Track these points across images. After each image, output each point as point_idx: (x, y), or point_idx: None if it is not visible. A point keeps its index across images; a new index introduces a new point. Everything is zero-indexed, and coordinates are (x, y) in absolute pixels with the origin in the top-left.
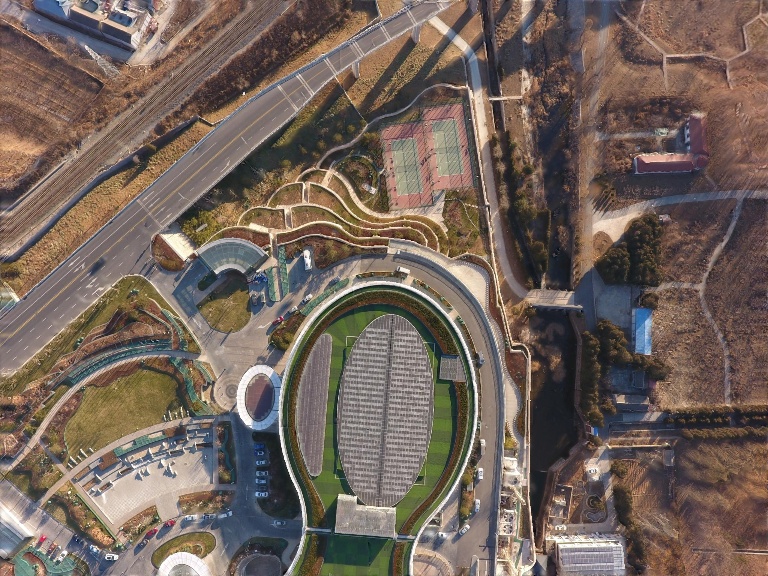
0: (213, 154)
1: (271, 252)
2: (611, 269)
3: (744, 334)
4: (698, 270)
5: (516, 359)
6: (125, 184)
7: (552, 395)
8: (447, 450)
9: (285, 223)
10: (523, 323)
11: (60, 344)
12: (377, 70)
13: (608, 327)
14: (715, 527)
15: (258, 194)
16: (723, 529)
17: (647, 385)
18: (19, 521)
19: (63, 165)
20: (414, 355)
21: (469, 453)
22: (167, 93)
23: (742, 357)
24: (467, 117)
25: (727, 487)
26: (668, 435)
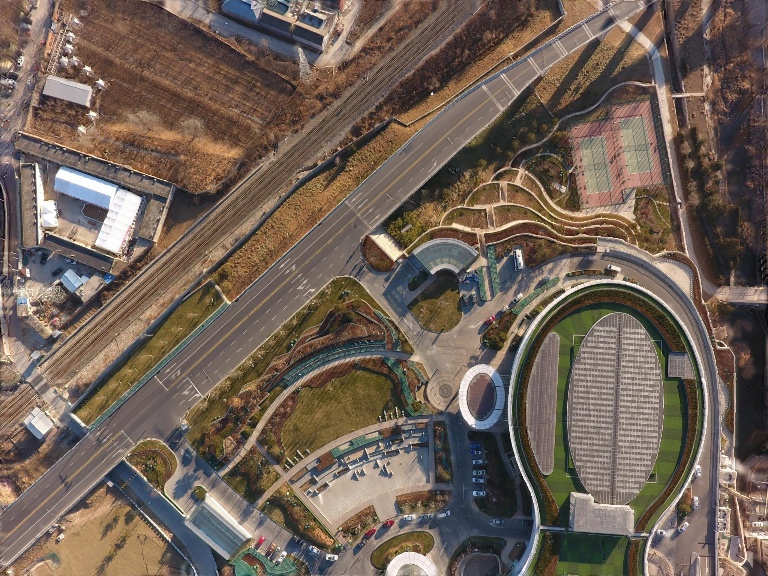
0: (420, 155)
1: (479, 252)
2: None
3: None
4: None
5: (724, 356)
6: (326, 186)
7: (741, 392)
8: (678, 447)
9: (488, 223)
10: (714, 320)
11: (273, 346)
12: (562, 69)
13: None
14: None
15: (455, 194)
16: None
17: None
18: (237, 522)
19: (261, 167)
20: (643, 353)
21: None
22: (363, 94)
23: None
24: (656, 114)
25: None
26: None
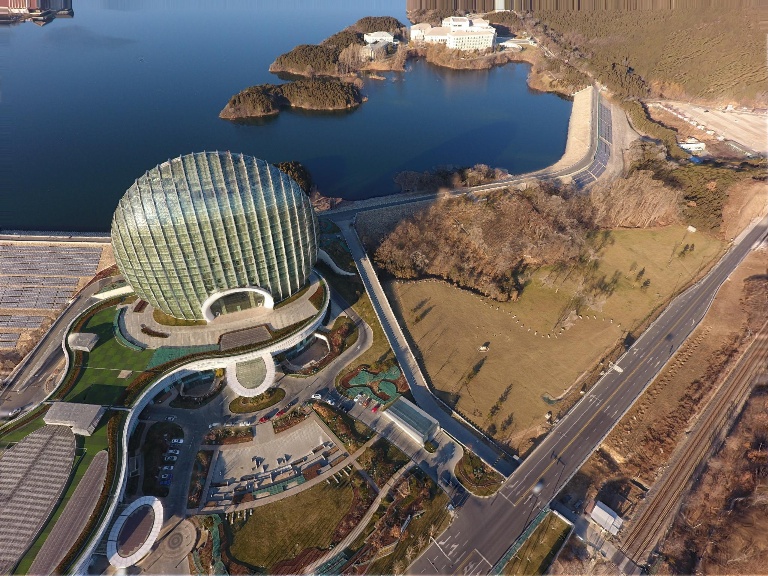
0: None
1: None
2: None
3: None
4: None
5: None
6: None
7: None
8: None
9: None
10: None
11: None
12: None
13: None
14: None
15: None
16: None
17: None
18: (396, 423)
19: None
20: None
21: None
22: None
23: None
24: None
25: None
26: None
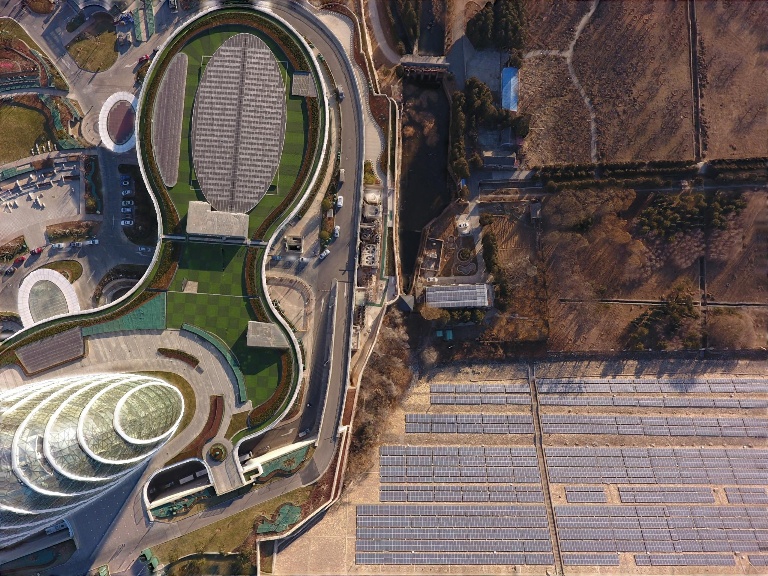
0: None
1: None
2: (476, 26)
3: (610, 98)
4: (566, 38)
5: (379, 101)
6: None
7: (426, 159)
8: (299, 162)
9: None
10: None
11: None
12: None
13: (473, 80)
14: (575, 266)
15: None
16: (588, 278)
17: (514, 142)
18: None
19: None
20: (267, 71)
21: (320, 163)
22: None
23: (608, 120)
24: None
25: (590, 235)
26: (536, 193)
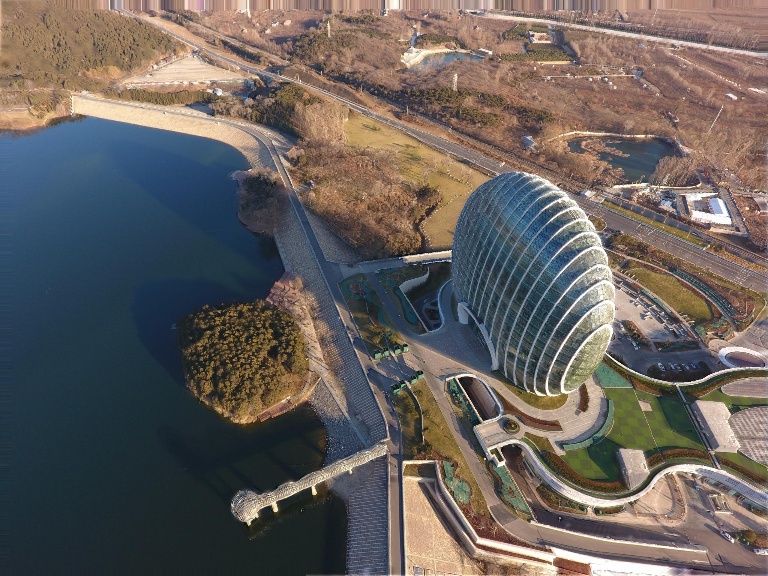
0: None
1: None
2: None
3: None
4: None
5: None
6: None
7: None
8: None
9: None
10: None
11: (692, 266)
12: None
13: None
14: None
15: None
16: None
17: None
18: None
19: None
20: None
21: None
22: None
23: None
24: None
25: None
26: None
